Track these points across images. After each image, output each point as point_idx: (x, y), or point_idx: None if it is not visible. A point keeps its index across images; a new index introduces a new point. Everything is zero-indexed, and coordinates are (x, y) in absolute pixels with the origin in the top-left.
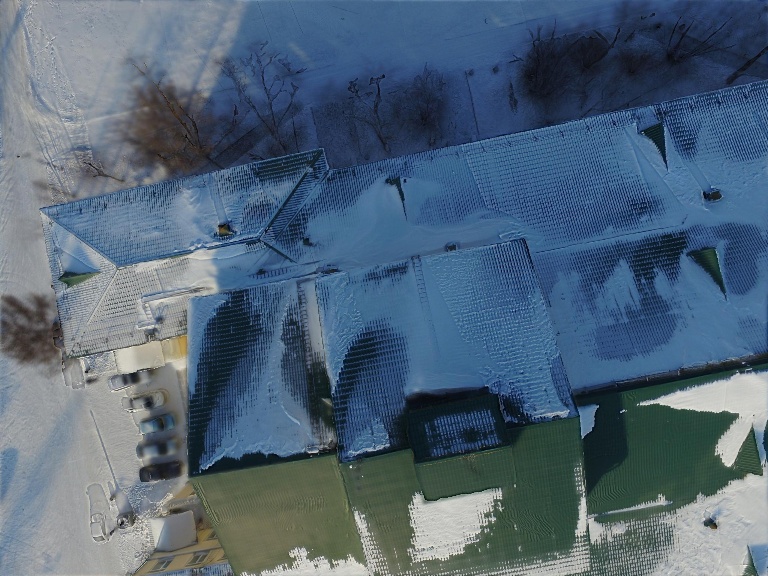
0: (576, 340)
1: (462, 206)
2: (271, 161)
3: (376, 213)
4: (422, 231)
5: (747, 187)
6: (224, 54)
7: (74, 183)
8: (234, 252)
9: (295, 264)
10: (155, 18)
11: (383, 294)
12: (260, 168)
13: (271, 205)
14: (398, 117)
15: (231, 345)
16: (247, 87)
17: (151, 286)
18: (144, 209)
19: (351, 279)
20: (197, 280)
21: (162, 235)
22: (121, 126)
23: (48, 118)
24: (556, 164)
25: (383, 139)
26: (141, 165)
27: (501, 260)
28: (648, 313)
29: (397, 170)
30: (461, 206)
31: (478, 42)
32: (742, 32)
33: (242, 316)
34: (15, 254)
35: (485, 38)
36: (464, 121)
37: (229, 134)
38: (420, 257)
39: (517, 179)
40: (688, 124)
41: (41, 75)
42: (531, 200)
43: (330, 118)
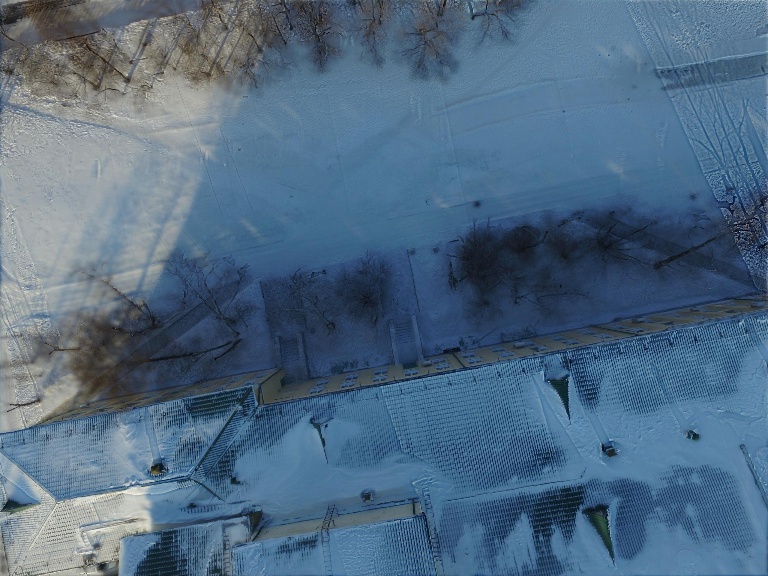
0: None
1: (380, 449)
2: (203, 397)
3: (299, 454)
4: (341, 475)
5: (642, 441)
6: (177, 229)
7: (33, 349)
8: (166, 489)
9: (223, 502)
10: (111, 193)
11: (293, 569)
12: (193, 404)
13: (202, 443)
14: (342, 294)
15: None
16: (199, 260)
17: (89, 517)
18: (83, 442)
19: (265, 551)
20: (132, 512)
21: (99, 470)
22: (78, 295)
23: (8, 286)
24: (468, 409)
25: (326, 322)
26: (97, 333)
27: (402, 538)
28: (543, 574)
29: (321, 410)
30: (379, 449)
31: (420, 222)
32: (669, 219)
33: (170, 560)
34: None
35: (426, 218)
36: (405, 298)
37: None
38: (329, 531)
39: (432, 423)
40: (591, 374)
41: (2, 245)
42: (444, 445)
43: (278, 292)
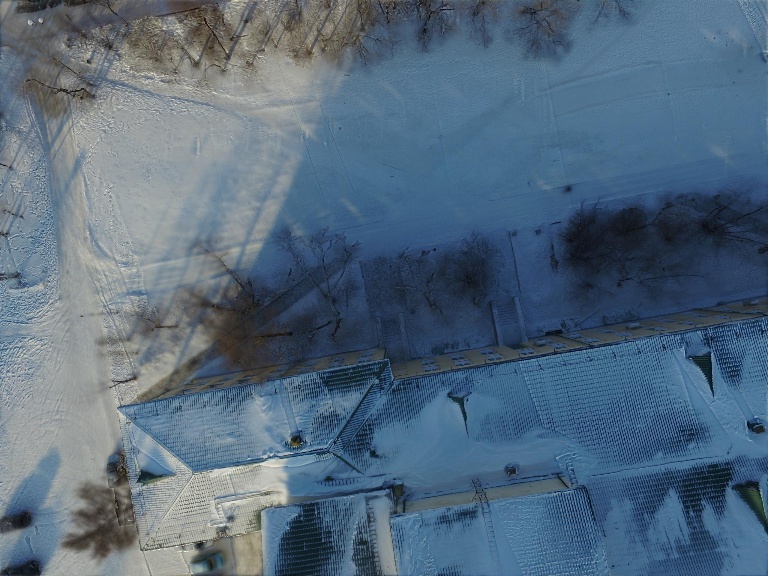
0: (630, 575)
1: (520, 423)
2: (339, 370)
3: (439, 428)
4: (483, 449)
5: None
6: (277, 207)
7: (129, 327)
8: (304, 461)
9: (362, 475)
10: (211, 170)
11: (455, 540)
12: (329, 377)
13: (339, 416)
14: (444, 275)
15: (305, 563)
16: None
17: (224, 489)
18: (218, 414)
19: (424, 521)
20: (268, 485)
21: (236, 441)
22: (175, 273)
23: (105, 263)
24: (609, 385)
25: (431, 302)
26: (194, 311)
27: (565, 510)
28: (696, 549)
29: (458, 384)
30: (519, 423)
31: (522, 204)
32: None
33: (314, 532)
34: (70, 393)
35: (528, 200)
36: (507, 279)
37: (280, 284)
38: (489, 502)
39: (572, 399)
40: (733, 351)
41: (99, 221)
42: (585, 421)
43: (378, 272)
